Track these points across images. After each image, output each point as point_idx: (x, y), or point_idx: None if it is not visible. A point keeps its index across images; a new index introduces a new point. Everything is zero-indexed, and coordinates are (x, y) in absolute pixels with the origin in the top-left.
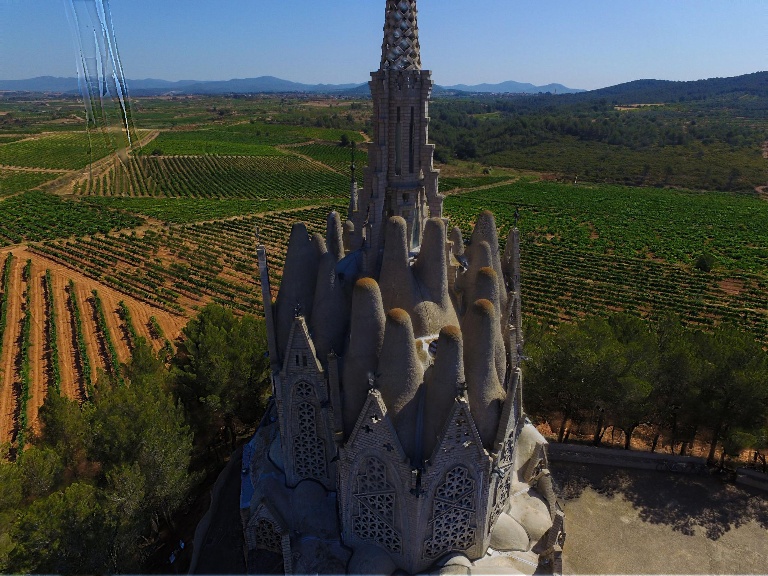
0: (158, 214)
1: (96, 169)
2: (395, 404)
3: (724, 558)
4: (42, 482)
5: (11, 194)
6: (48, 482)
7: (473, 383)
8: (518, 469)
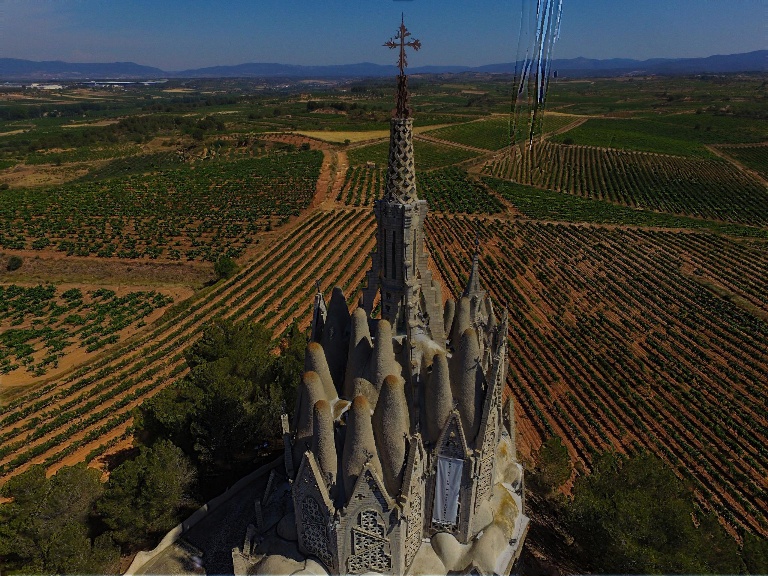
0: (522, 205)
1: (500, 155)
2: (300, 432)
3: None
4: (257, 372)
5: (440, 166)
6: (260, 374)
7: (344, 453)
8: (452, 570)
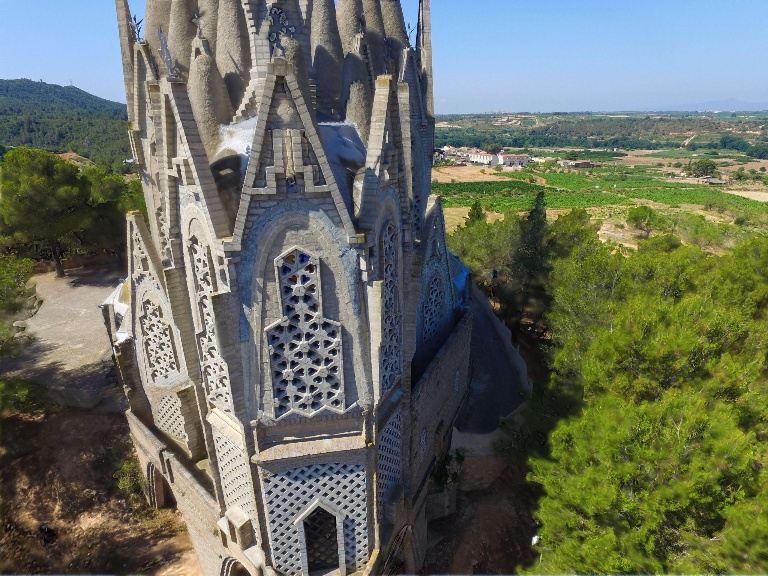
0: None
1: None
2: None
3: (41, 327)
4: None
5: None
6: None
7: None
8: None
